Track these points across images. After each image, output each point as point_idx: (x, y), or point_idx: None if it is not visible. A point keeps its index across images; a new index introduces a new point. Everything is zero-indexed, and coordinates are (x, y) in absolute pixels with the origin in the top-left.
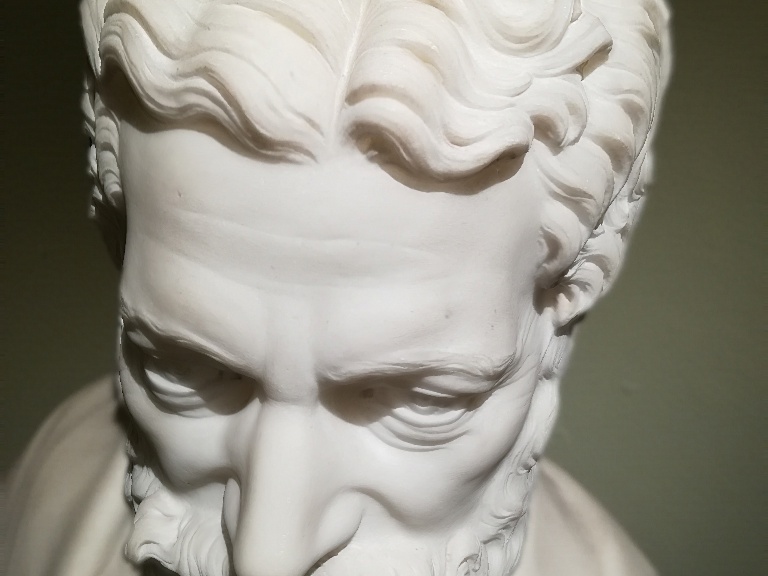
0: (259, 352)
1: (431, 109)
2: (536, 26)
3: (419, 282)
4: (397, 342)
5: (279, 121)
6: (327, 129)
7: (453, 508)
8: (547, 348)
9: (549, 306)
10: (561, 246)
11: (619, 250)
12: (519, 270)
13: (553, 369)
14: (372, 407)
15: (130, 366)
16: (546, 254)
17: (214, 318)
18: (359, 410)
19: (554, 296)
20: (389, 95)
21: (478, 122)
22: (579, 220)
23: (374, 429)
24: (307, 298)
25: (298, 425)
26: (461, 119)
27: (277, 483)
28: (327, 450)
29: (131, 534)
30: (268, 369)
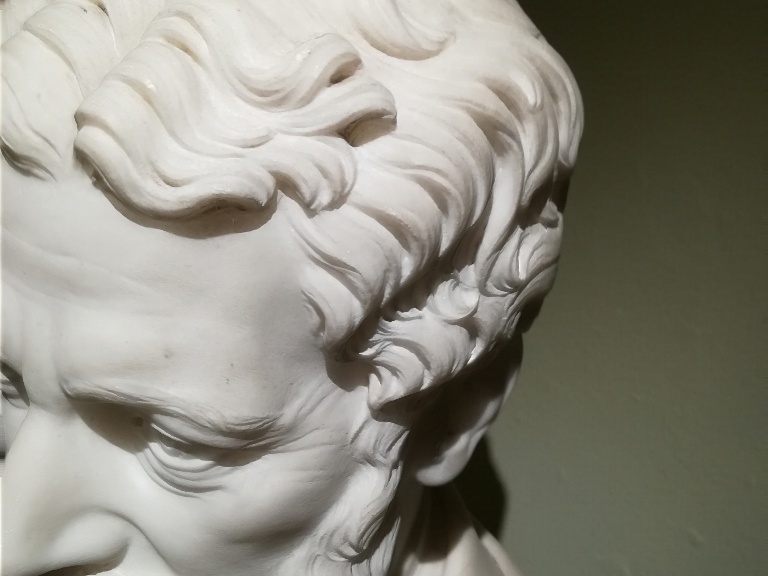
0: (16, 351)
1: (134, 144)
2: (276, 81)
3: (139, 315)
4: (112, 369)
5: (19, 136)
6: (65, 151)
7: (225, 567)
8: (360, 430)
9: (365, 385)
10: (325, 316)
11: (456, 344)
12: (279, 331)
13: (376, 456)
14: (139, 436)
15: None
16: (318, 322)
17: None
18: (130, 436)
19: (367, 375)
20: (96, 125)
21: (191, 165)
22: (353, 293)
23: (140, 459)
24: (49, 308)
25: (45, 430)
26: (173, 160)
27: (14, 479)
28: (77, 464)
29: None
30: (22, 369)
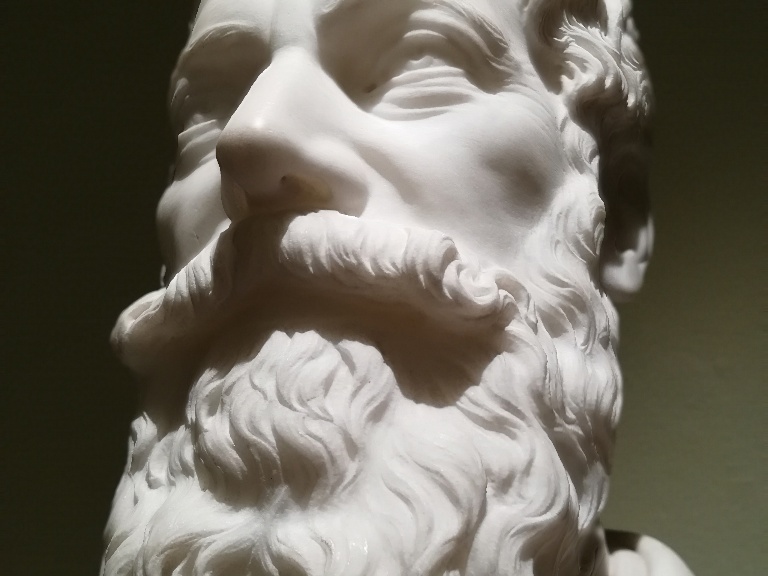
0: (267, 13)
1: None
2: None
3: None
4: None
5: None
6: None
7: (477, 207)
8: (564, 123)
9: (557, 94)
10: None
11: None
12: None
13: (582, 157)
14: None
15: None
16: None
17: (234, 0)
18: (363, 101)
19: (558, 81)
20: None
21: None
22: None
23: (377, 110)
24: None
25: (296, 58)
26: None
27: (269, 80)
28: (325, 91)
29: None
30: (273, 23)
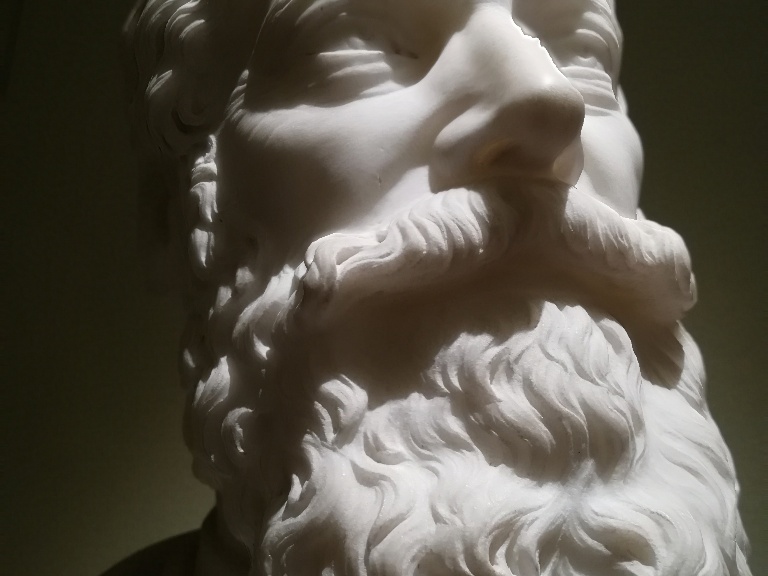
0: None
1: None
2: None
3: None
4: None
5: None
6: None
7: None
8: None
9: None
10: None
11: None
12: None
13: None
14: None
15: (274, 106)
16: None
17: None
18: None
19: None
20: None
21: None
22: None
23: None
24: None
25: None
26: None
27: None
28: None
29: (319, 251)
30: None
